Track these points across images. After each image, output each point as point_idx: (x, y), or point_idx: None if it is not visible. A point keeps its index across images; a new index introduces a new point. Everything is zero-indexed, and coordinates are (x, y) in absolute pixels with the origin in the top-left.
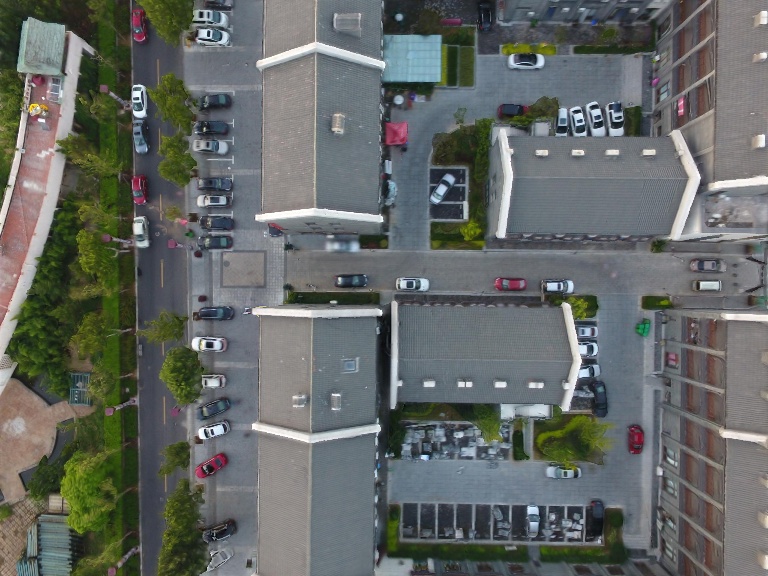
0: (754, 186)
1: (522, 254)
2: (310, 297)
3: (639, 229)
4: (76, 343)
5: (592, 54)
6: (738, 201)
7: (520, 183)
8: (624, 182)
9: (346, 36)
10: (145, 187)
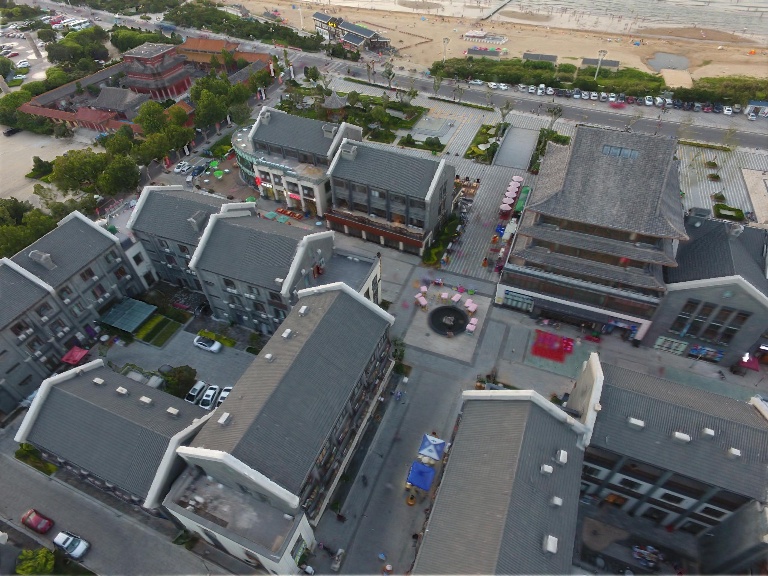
0: (201, 460)
1: (77, 496)
2: None
3: (126, 483)
4: None
5: None
6: (229, 493)
7: (56, 394)
8: (127, 424)
9: (39, 265)
10: None
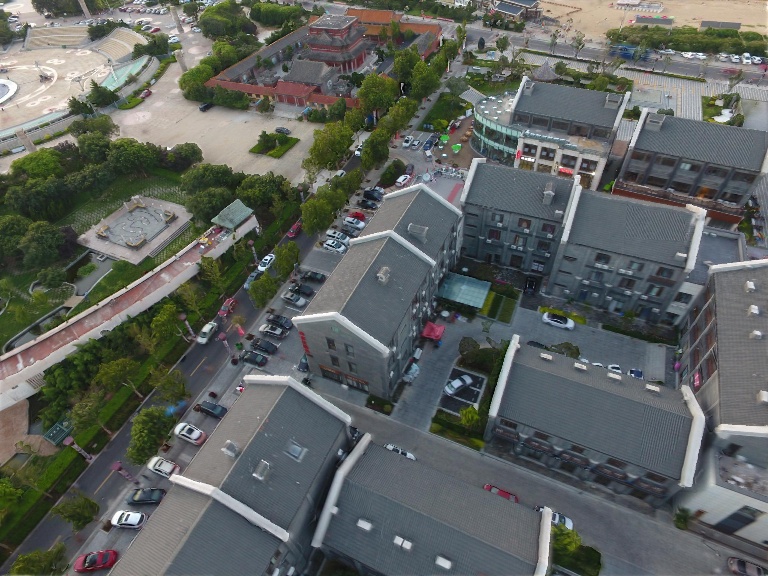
0: (766, 439)
1: (521, 472)
2: None
3: (642, 460)
4: (99, 371)
5: (619, 333)
6: (764, 473)
7: (519, 369)
8: (623, 400)
9: (414, 239)
10: (232, 307)
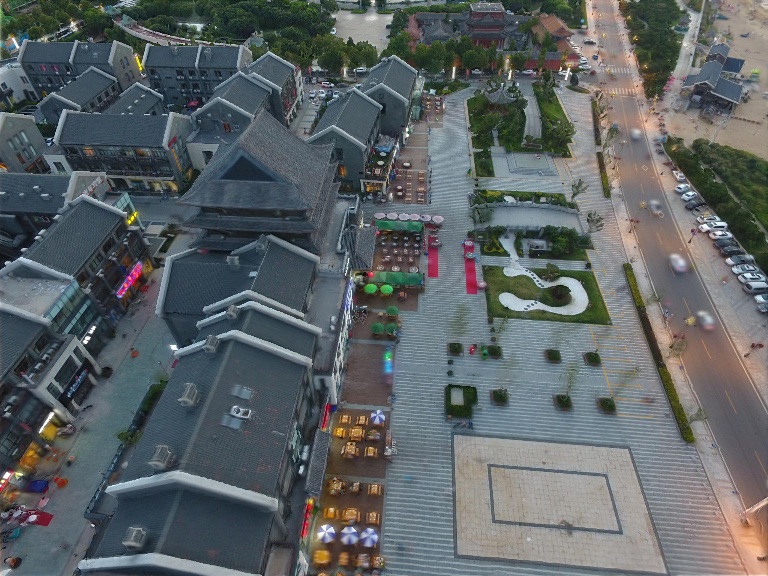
0: None
1: None
2: None
3: None
4: None
5: None
6: None
7: None
8: None
9: None
10: None
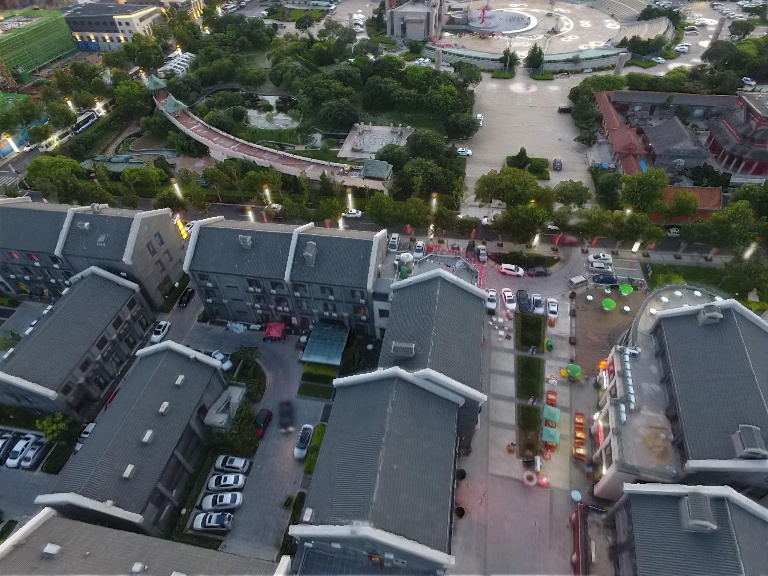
0: None
1: None
2: None
3: None
4: None
5: None
6: None
7: None
8: None
9: None
10: None
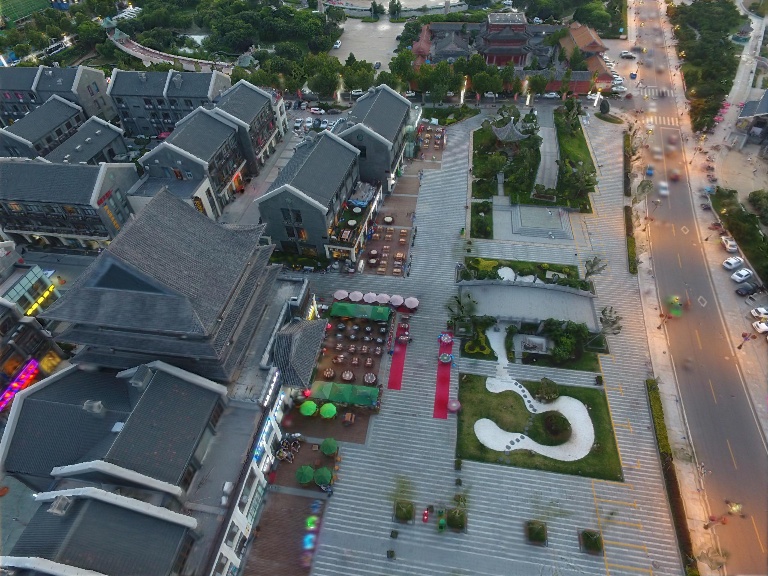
0: None
1: None
2: (118, 118)
3: None
4: None
5: None
6: None
7: None
8: None
9: None
10: None
